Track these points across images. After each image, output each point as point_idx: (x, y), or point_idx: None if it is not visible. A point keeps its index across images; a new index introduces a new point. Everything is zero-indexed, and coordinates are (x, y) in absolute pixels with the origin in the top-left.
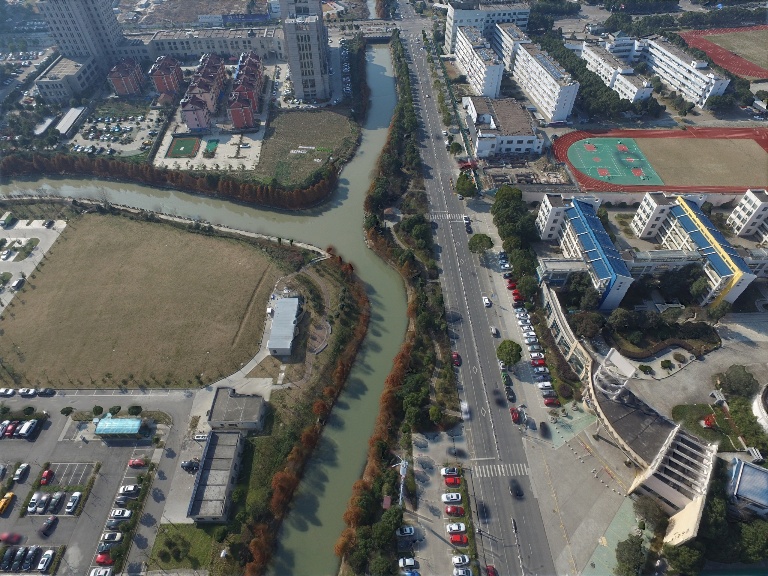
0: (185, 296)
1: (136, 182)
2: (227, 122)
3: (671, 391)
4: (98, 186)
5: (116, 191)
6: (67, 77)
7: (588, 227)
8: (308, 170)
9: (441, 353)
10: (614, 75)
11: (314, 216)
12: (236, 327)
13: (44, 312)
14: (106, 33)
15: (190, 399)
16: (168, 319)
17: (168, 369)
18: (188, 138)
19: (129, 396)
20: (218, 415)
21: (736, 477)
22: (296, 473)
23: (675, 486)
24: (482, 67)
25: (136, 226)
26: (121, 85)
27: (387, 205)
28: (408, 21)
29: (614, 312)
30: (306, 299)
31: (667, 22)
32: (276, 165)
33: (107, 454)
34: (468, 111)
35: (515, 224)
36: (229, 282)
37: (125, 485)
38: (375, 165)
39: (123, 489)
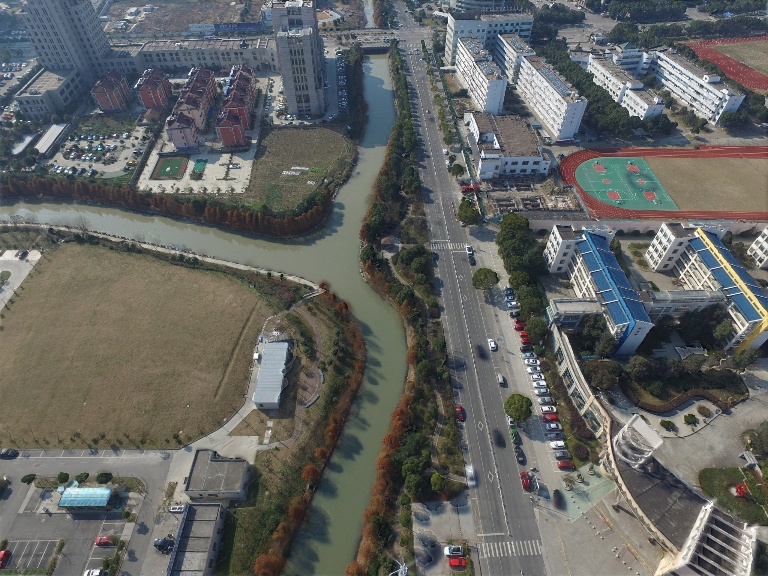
0: (165, 340)
1: (118, 206)
2: (216, 140)
3: (697, 451)
4: (79, 210)
5: (98, 215)
6: (49, 92)
7: (602, 264)
8: (301, 194)
9: (443, 406)
10: (623, 90)
11: (307, 245)
12: (220, 376)
13: (11, 358)
14: (91, 45)
15: (167, 462)
16: (145, 367)
17: (144, 426)
18: (175, 158)
19: (100, 458)
20: (196, 483)
21: None
22: (283, 551)
23: None
24: (484, 82)
25: (116, 257)
26: (106, 100)
27: (385, 233)
28: (407, 30)
29: (632, 360)
30: (296, 345)
31: (675, 32)
32: (267, 188)
33: (72, 529)
34: (470, 128)
35: (522, 257)
36: (213, 323)
37: (90, 569)
38: (372, 189)
39: (88, 574)
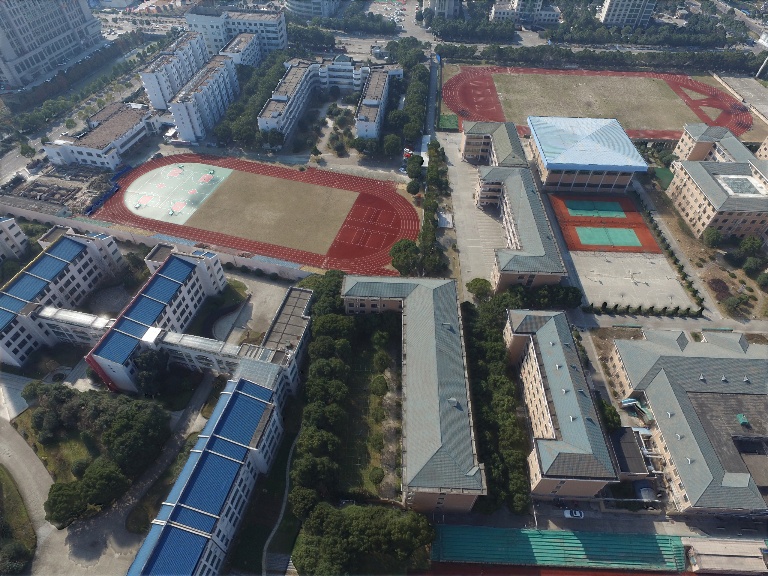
0: None
1: None
2: None
3: None
4: None
5: None
6: None
7: None
8: None
9: None
10: None
11: None
12: None
13: None
14: None
15: None
16: None
17: None
18: None
19: None
20: None
21: None
22: None
23: None
24: None
25: None
26: None
27: None
28: None
29: None
30: None
31: (463, 53)
32: None
33: None
34: None
35: None
36: None
37: None
38: None
39: None
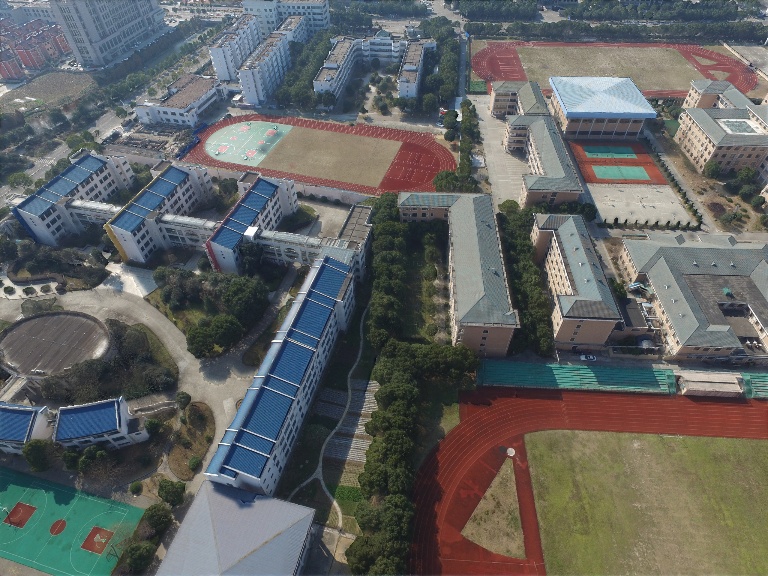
0: None
1: None
2: None
3: (4, 308)
4: None
5: None
6: None
7: None
8: None
9: None
10: None
11: None
12: None
13: None
14: None
15: None
16: None
17: None
18: None
19: None
20: None
21: None
22: None
23: None
24: None
25: None
26: None
27: (22, 147)
28: None
29: None
30: None
31: (490, 30)
32: None
33: None
34: None
35: None
36: None
37: None
38: None
39: None
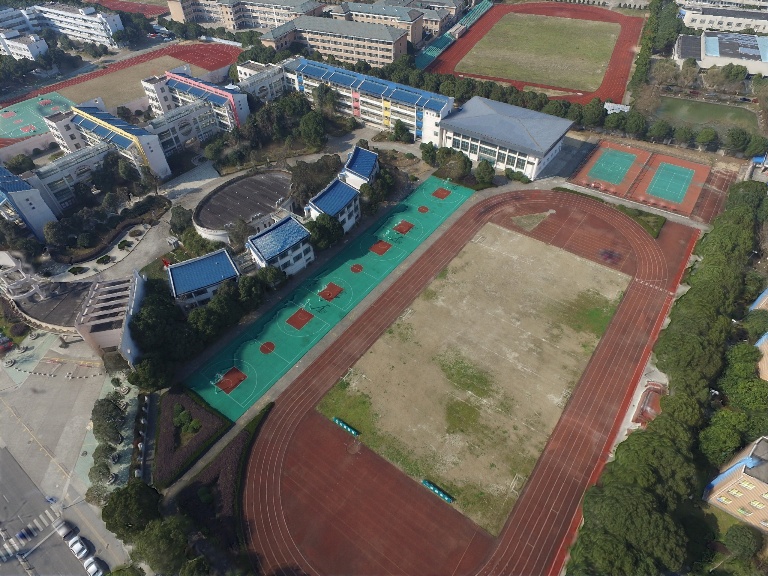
0: None
1: None
2: None
3: (134, 262)
4: None
5: None
6: None
7: None
8: None
9: None
10: (3, 43)
11: None
12: None
13: None
14: None
15: None
16: None
17: None
18: None
19: None
20: None
21: (170, 283)
22: None
23: (118, 327)
24: None
25: None
26: None
27: None
28: None
29: None
30: None
31: None
32: None
33: None
34: None
35: None
36: None
37: None
38: None
39: None
